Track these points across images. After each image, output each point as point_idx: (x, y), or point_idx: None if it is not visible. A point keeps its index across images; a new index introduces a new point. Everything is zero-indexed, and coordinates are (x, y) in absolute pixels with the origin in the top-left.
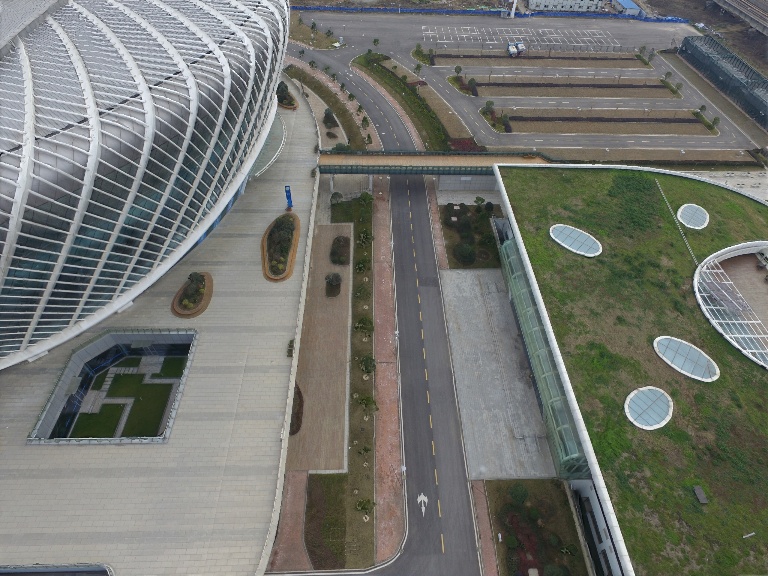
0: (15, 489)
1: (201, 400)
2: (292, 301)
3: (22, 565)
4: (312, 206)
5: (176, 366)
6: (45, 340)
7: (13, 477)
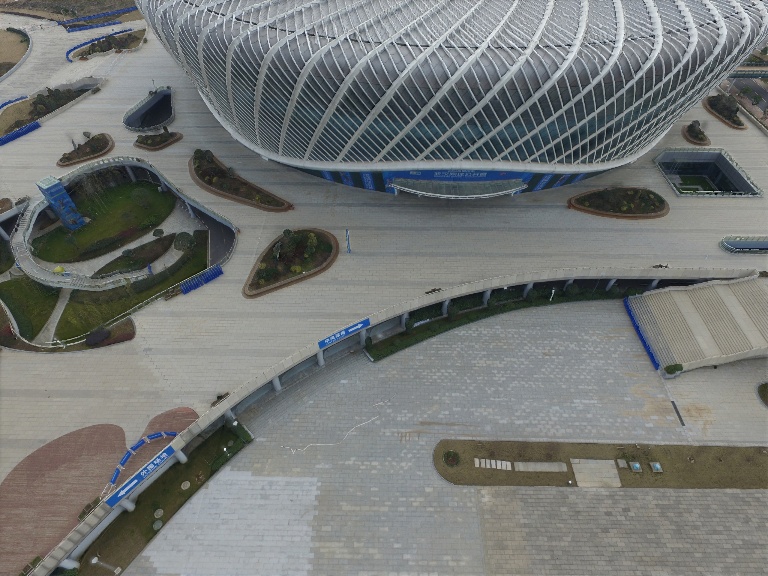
0: (696, 213)
1: (761, 181)
2: (764, 139)
3: (749, 236)
4: (724, 92)
5: (692, 180)
6: (642, 149)
7: (688, 209)
